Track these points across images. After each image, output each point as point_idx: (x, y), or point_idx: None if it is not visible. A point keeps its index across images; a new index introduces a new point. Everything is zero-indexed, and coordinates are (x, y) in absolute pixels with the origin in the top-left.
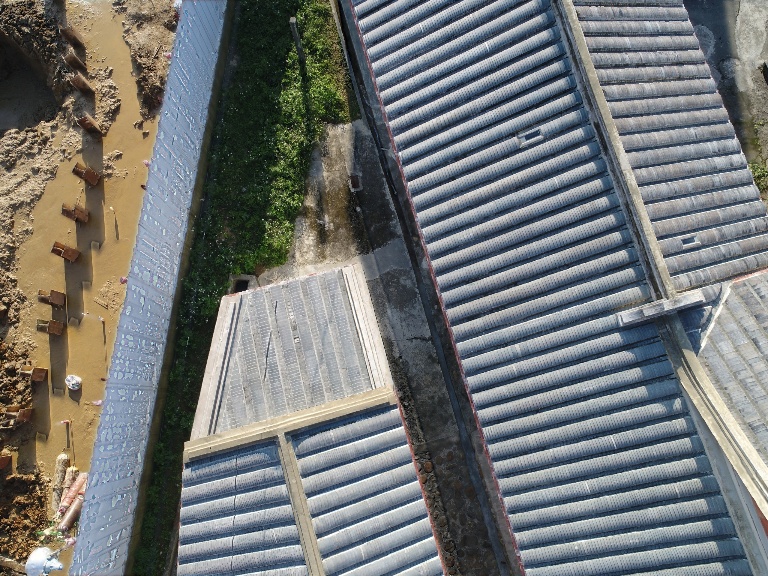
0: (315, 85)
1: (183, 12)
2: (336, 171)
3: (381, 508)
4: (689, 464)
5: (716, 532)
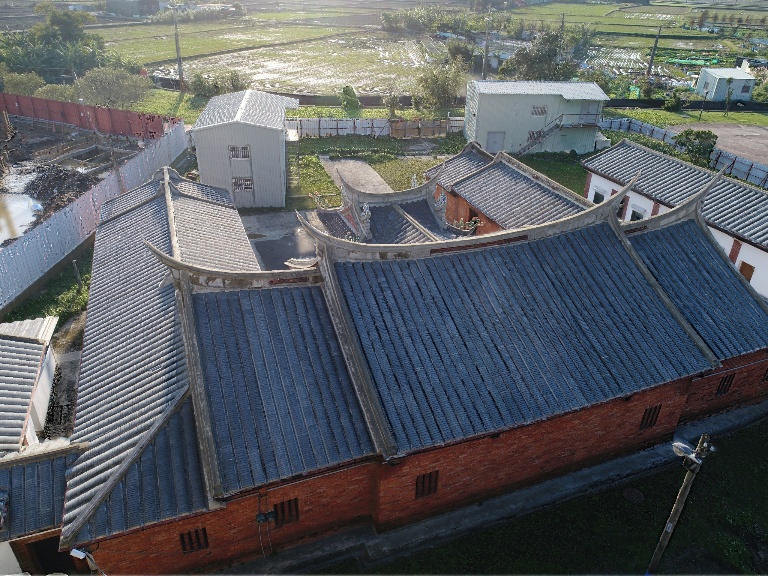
0: (83, 296)
1: (15, 245)
2: (79, 325)
3: (6, 367)
4: (171, 318)
5: (174, 335)
